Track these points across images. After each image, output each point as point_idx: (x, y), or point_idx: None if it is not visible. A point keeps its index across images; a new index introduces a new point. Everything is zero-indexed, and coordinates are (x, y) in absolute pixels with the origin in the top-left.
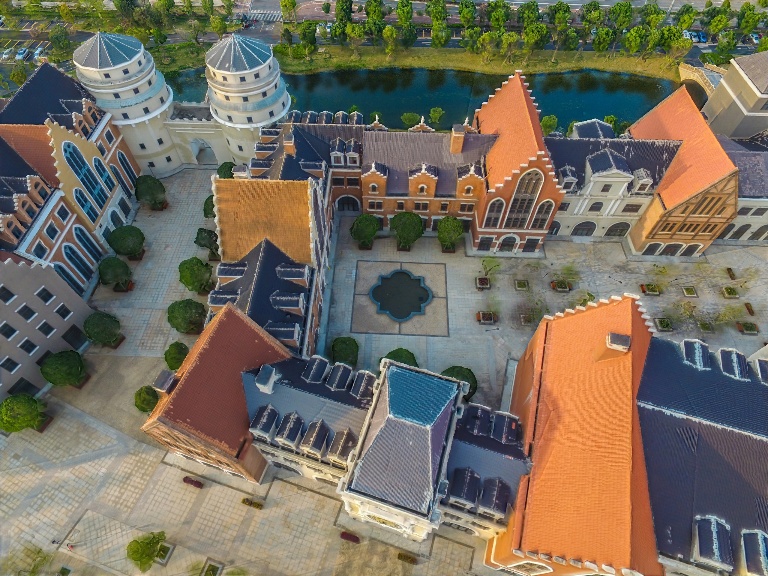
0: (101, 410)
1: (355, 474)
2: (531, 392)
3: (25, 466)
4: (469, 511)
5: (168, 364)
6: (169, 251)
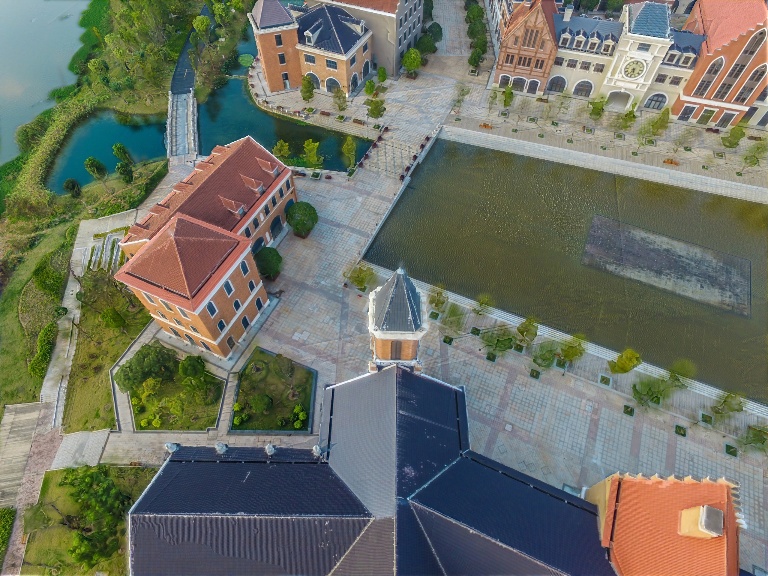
0: (441, 73)
1: (632, 27)
2: (696, 25)
3: (414, 90)
4: (674, 65)
5: (478, 47)
6: (440, 19)
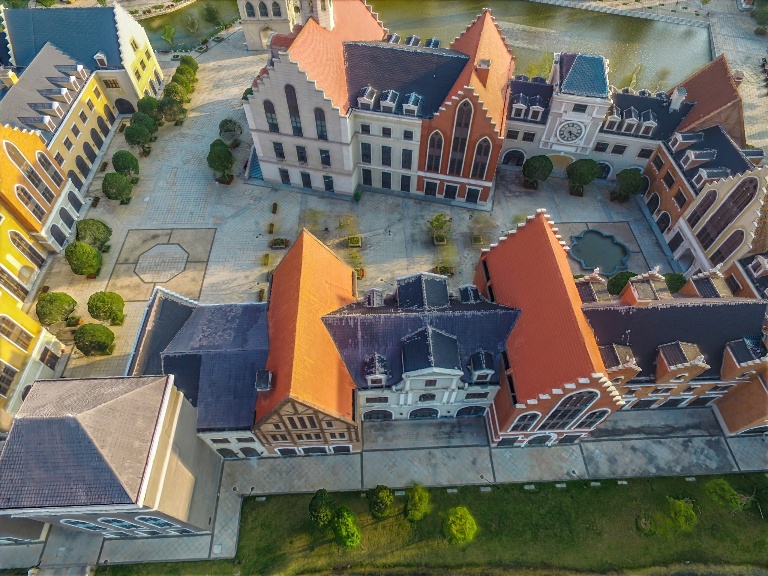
0: None
1: None
2: None
3: None
4: None
5: None
6: None
